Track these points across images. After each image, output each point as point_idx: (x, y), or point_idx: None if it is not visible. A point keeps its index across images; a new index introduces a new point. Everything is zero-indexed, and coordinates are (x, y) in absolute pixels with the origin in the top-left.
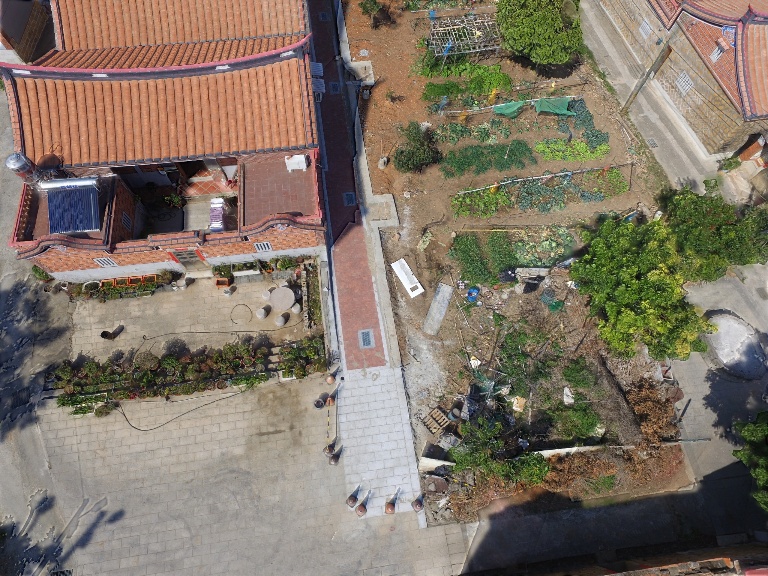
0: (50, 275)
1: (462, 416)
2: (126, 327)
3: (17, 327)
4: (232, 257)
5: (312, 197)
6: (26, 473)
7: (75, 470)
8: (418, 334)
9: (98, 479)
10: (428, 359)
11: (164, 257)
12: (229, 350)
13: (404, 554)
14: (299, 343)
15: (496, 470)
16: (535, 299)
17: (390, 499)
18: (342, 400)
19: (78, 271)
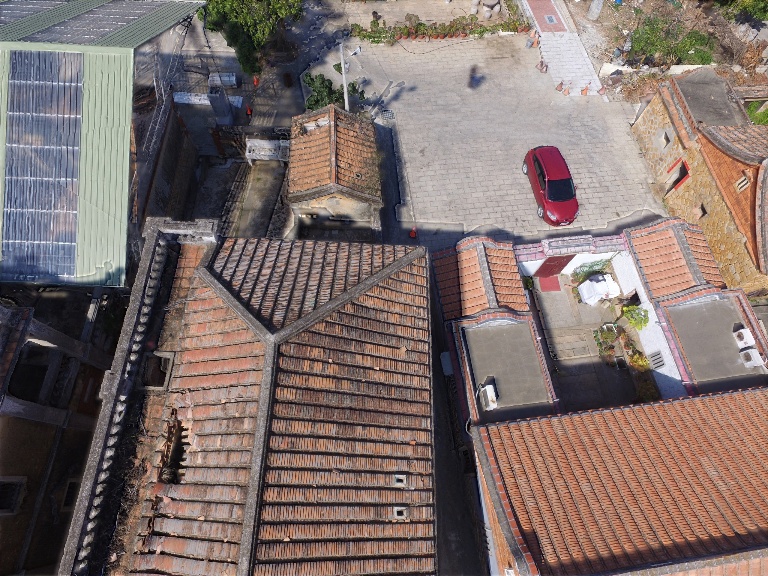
0: None
1: (624, 50)
2: (383, 16)
3: (313, 11)
4: None
5: None
6: None
7: (379, 69)
8: (584, 20)
9: (396, 73)
10: (593, 32)
11: None
12: (463, 18)
13: (597, 112)
14: (505, 22)
15: (661, 49)
16: (662, 2)
17: (583, 89)
18: (542, 45)
19: None
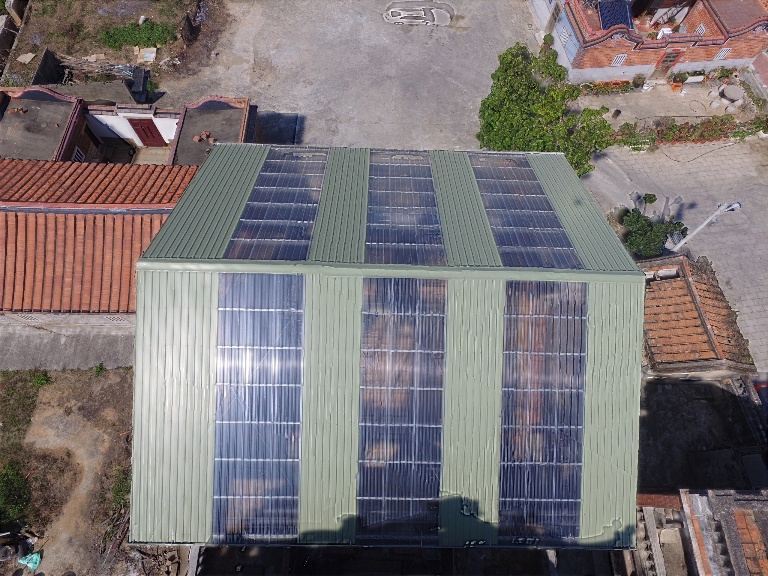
0: (567, 74)
1: None
2: None
3: None
4: (692, 64)
5: (766, 15)
6: (617, 183)
7: (650, 182)
8: None
9: (669, 187)
10: None
11: (656, 59)
12: (718, 118)
13: None
14: (756, 119)
15: None
16: None
17: None
18: None
19: (591, 69)
